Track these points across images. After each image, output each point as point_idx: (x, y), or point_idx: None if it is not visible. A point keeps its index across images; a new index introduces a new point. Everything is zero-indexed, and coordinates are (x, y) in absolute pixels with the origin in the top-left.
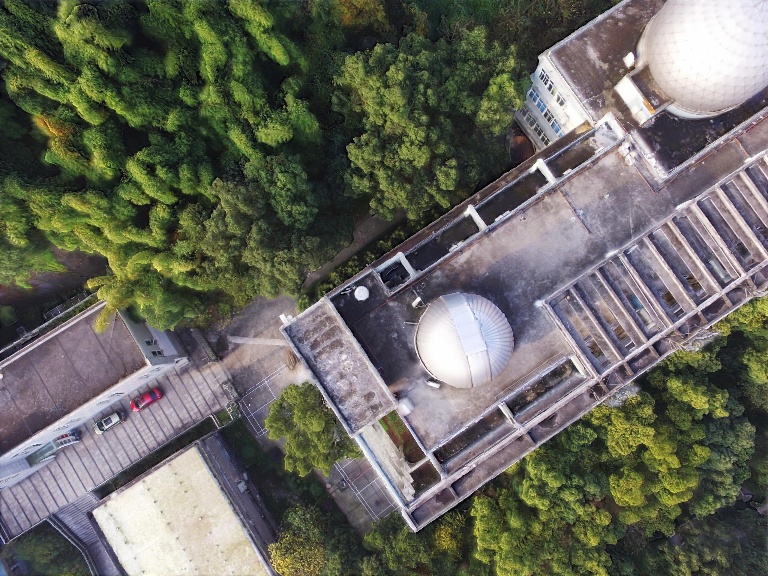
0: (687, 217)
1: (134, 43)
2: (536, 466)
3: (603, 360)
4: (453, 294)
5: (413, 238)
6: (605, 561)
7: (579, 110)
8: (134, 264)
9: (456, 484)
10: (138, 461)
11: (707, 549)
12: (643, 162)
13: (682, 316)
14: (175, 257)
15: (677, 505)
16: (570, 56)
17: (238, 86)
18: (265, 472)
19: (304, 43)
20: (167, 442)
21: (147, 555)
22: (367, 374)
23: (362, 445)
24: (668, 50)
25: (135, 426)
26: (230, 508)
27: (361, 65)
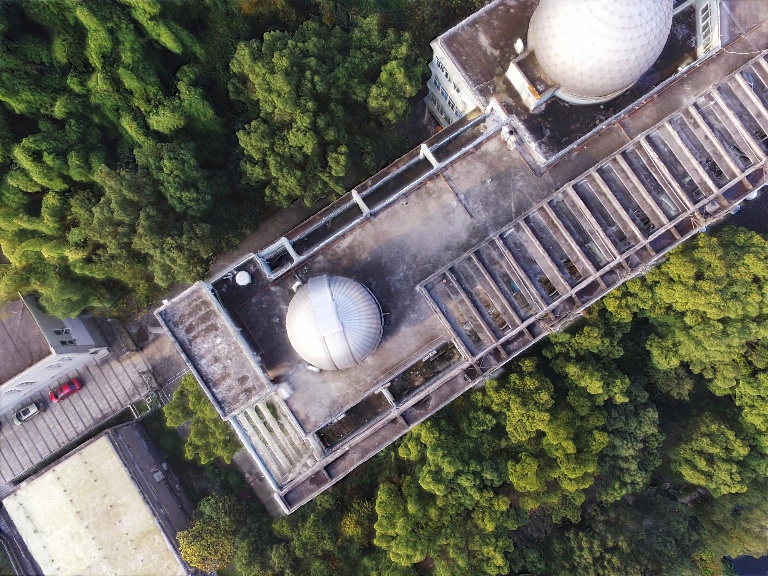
0: (564, 200)
1: (19, 30)
2: (433, 452)
3: (478, 343)
4: (319, 276)
5: (304, 224)
6: (506, 547)
7: (470, 96)
8: (28, 251)
9: (330, 467)
10: (57, 451)
11: (609, 534)
12: (526, 147)
13: (557, 299)
14: (68, 244)
15: (581, 491)
16: (462, 43)
17: (126, 73)
18: (186, 462)
19: (206, 32)
20: (85, 432)
21: (56, 544)
22: (241, 357)
23: (236, 428)
24: (546, 35)
25: (55, 417)
26: (140, 497)
27: (247, 52)
